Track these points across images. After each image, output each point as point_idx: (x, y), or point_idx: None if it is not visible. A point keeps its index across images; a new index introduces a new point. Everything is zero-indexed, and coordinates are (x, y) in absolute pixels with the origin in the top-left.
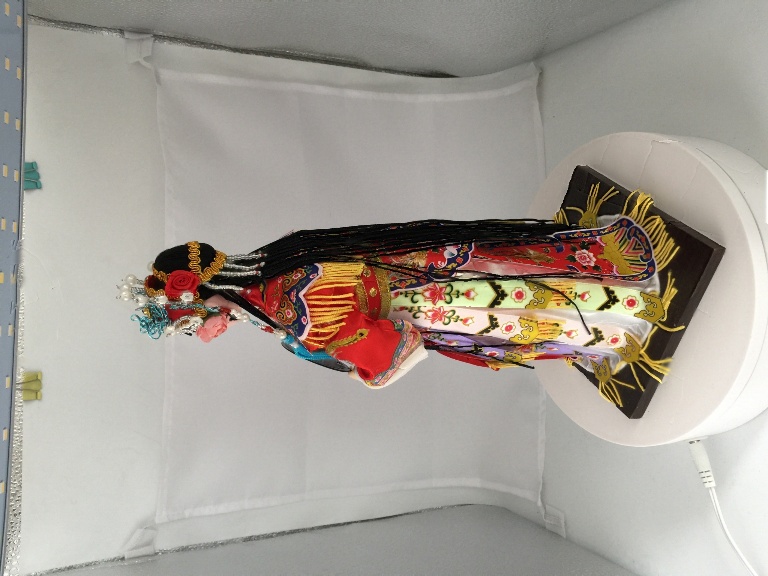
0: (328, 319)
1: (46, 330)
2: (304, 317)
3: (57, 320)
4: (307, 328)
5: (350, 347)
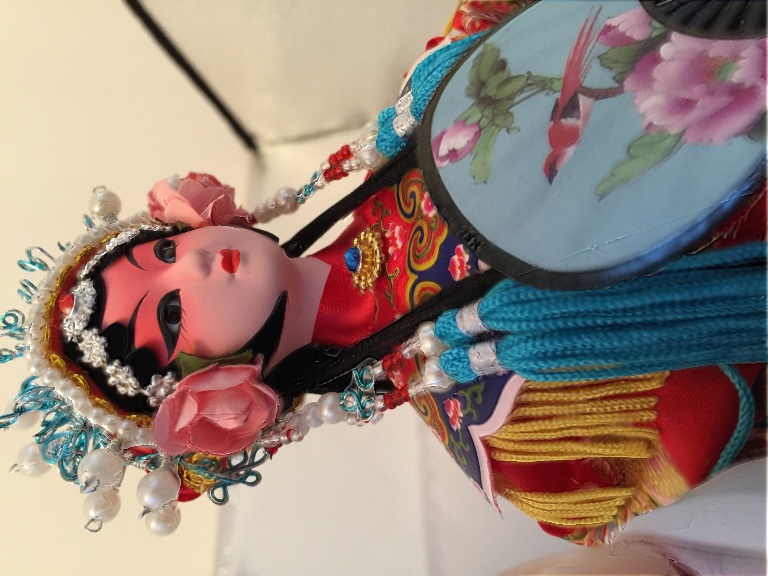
0: None
1: None
2: None
3: None
4: None
5: None
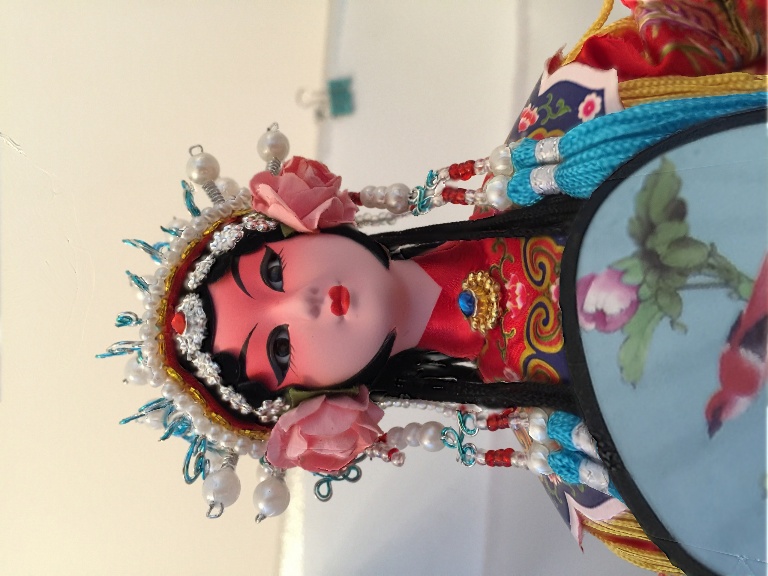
0: None
1: (2, 192)
2: None
3: (19, 229)
4: None
5: None
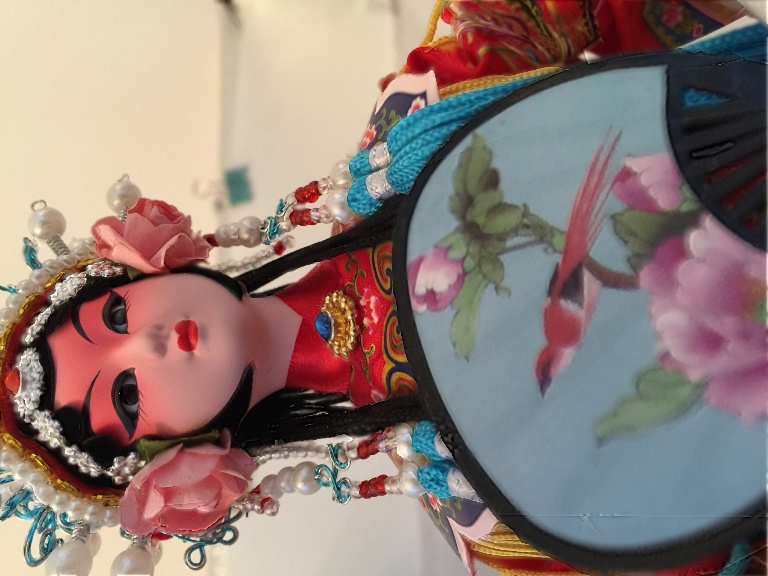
0: None
1: None
2: None
3: None
4: None
5: None
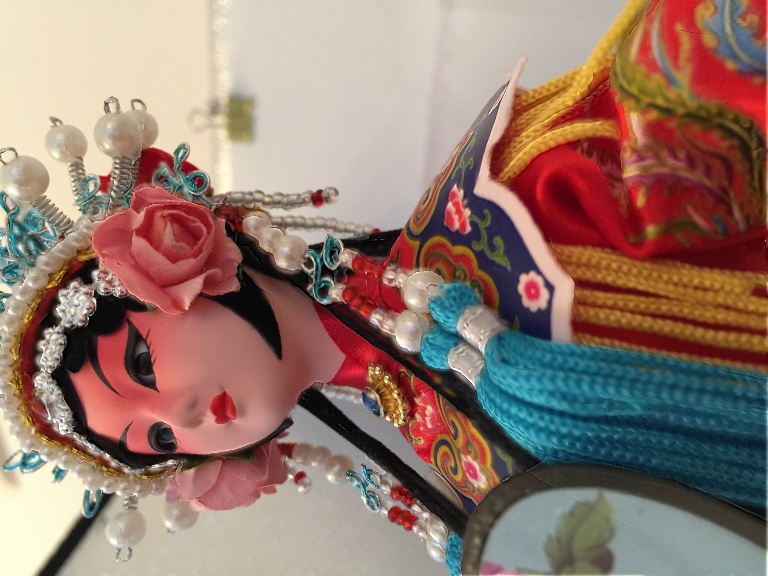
0: None
1: None
2: (497, 100)
3: None
4: (507, 90)
5: None
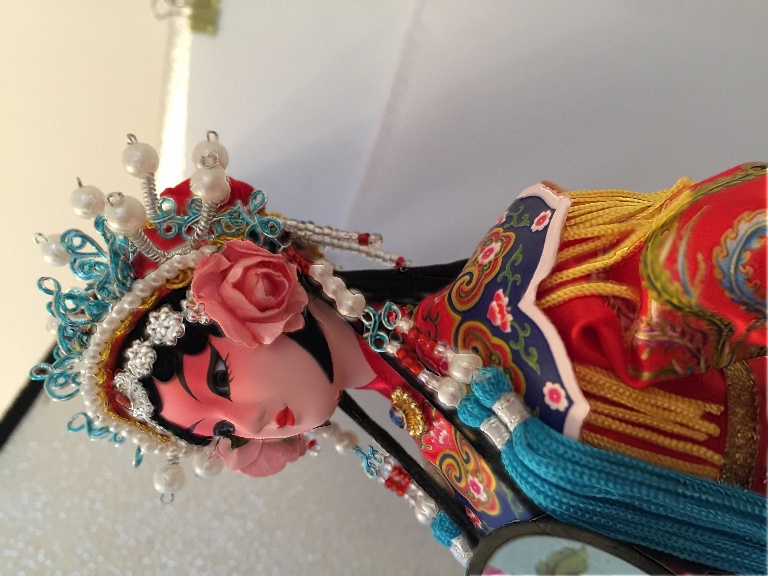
0: (621, 209)
1: None
2: (539, 216)
3: None
4: (553, 224)
5: (734, 188)
